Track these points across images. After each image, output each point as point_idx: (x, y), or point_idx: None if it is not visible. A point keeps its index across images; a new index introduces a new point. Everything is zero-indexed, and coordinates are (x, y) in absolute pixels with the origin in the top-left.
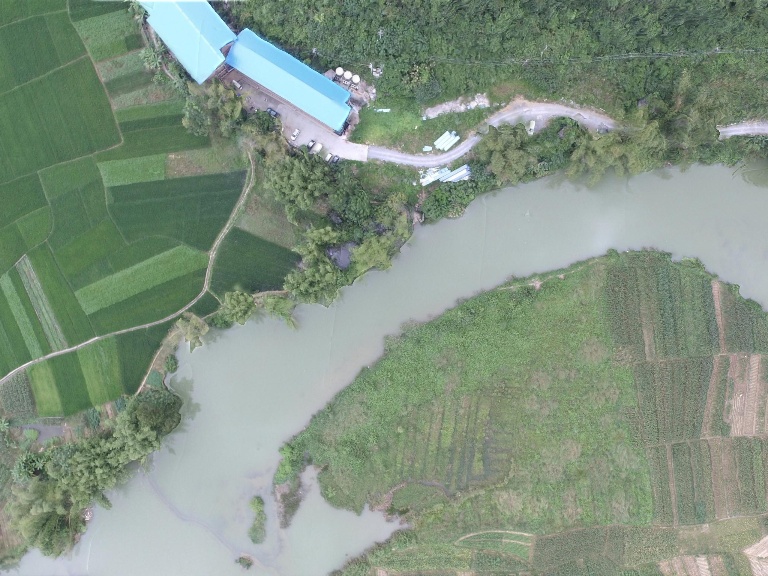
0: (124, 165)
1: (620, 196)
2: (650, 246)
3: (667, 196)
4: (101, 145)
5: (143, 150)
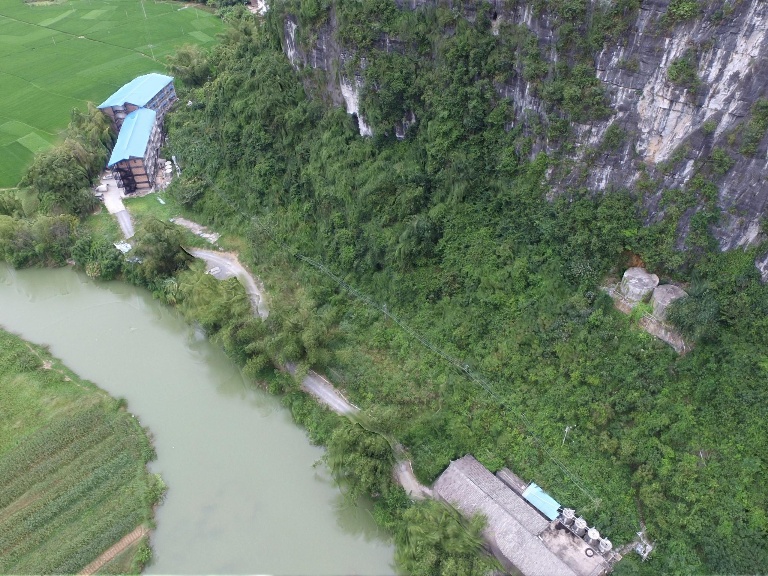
0: (38, 139)
1: (205, 383)
2: (154, 432)
3: (230, 413)
4: (48, 129)
5: (55, 141)
